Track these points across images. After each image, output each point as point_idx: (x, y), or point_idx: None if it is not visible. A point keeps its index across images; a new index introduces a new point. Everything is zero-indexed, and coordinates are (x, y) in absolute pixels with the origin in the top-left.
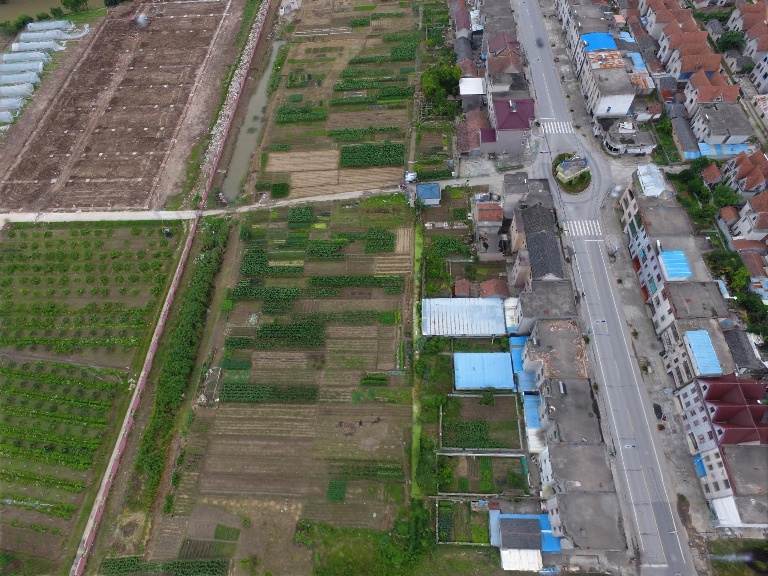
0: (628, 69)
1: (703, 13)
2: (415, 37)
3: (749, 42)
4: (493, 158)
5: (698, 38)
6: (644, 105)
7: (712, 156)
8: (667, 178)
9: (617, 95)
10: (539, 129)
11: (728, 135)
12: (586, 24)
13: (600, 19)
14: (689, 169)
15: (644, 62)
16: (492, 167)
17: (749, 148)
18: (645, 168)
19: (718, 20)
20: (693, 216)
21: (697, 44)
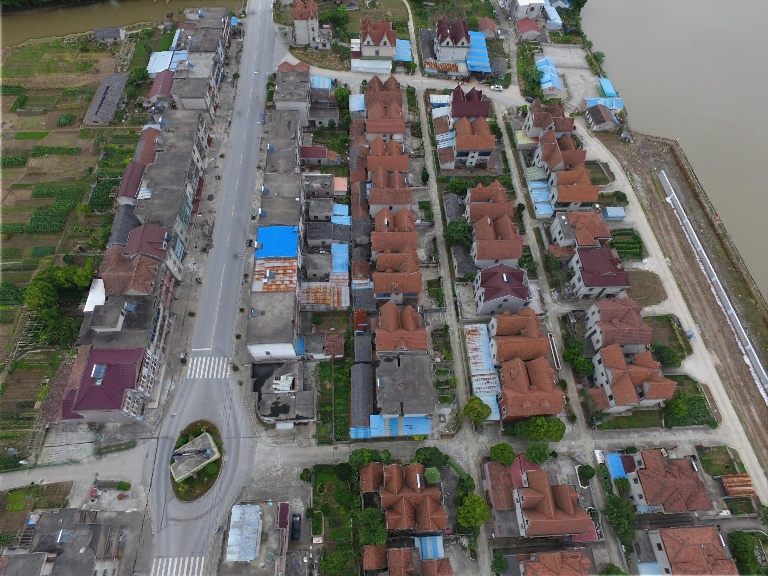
0: (325, 271)
1: (449, 176)
2: (75, 193)
3: (473, 242)
4: (96, 429)
5: (406, 239)
6: (323, 340)
7: (385, 436)
8: (321, 472)
9: (267, 344)
10: (183, 370)
11: (400, 413)
12: (273, 208)
13: (294, 200)
14: (347, 463)
15: (352, 256)
16: (90, 445)
17: (443, 413)
18: (239, 513)
19: (459, 192)
20: (337, 547)
21: (397, 254)
